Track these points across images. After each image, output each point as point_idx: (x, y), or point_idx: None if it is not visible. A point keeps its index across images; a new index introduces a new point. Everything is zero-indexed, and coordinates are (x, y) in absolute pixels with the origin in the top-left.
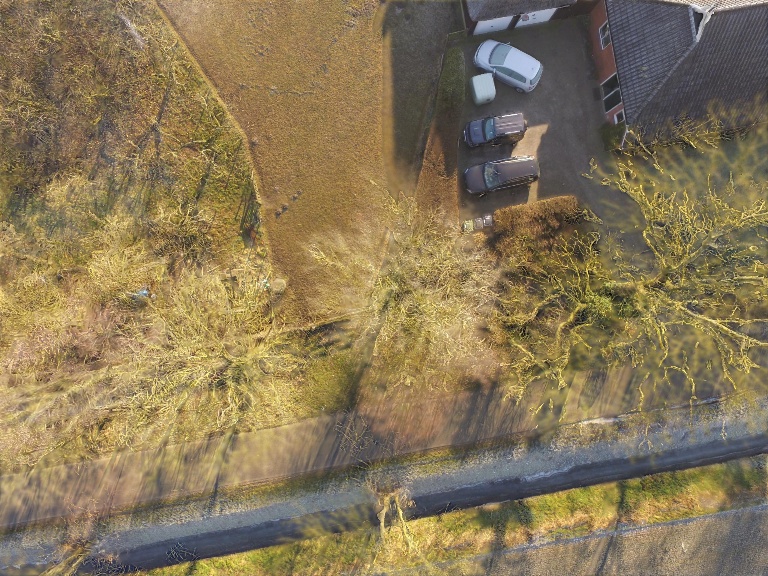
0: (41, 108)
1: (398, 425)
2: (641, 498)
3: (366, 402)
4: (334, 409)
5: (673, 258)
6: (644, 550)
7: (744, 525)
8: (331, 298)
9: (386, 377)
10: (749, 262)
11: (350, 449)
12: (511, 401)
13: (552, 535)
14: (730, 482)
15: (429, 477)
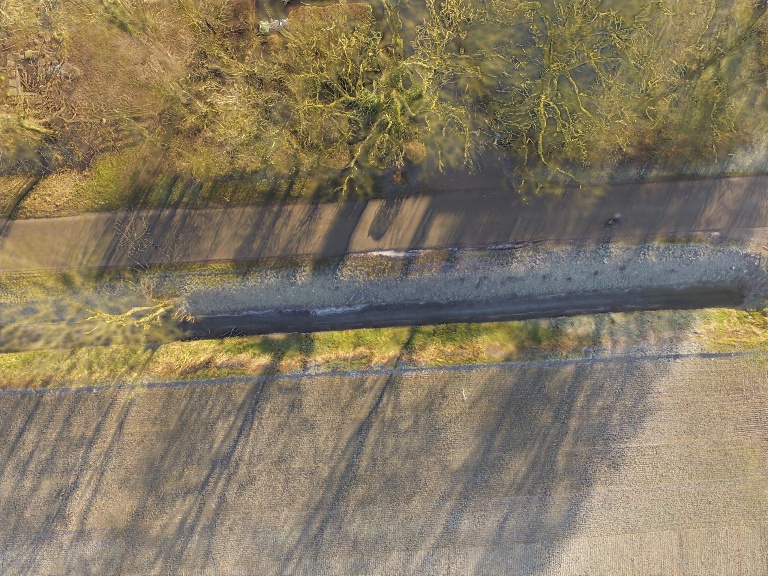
0: None
1: (180, 231)
2: (429, 342)
3: (149, 203)
4: (115, 206)
5: (427, 38)
6: (422, 393)
7: (529, 379)
8: (125, 93)
9: (173, 181)
10: (514, 61)
11: (128, 250)
12: (299, 221)
13: (328, 365)
14: (523, 337)
15: (208, 290)
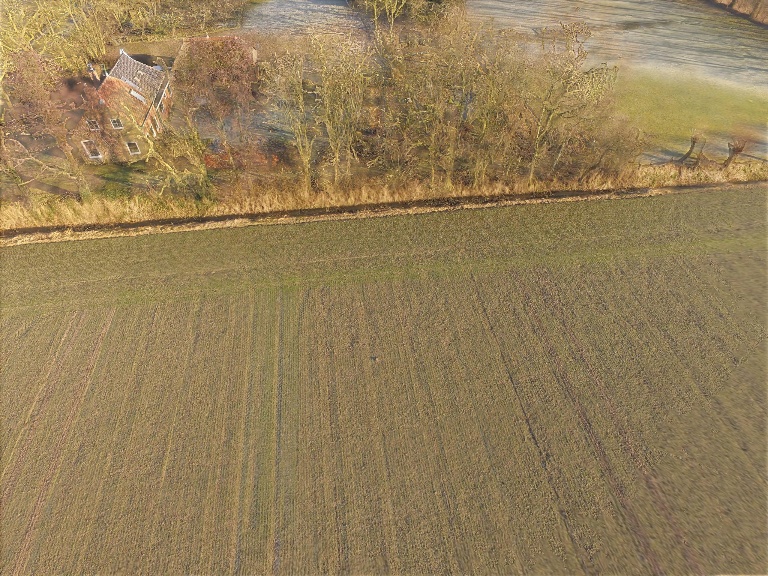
0: (193, 2)
1: None
2: None
3: None
4: None
5: None
6: None
7: None
8: None
9: None
10: None
11: None
12: None
13: None
14: None
15: None
